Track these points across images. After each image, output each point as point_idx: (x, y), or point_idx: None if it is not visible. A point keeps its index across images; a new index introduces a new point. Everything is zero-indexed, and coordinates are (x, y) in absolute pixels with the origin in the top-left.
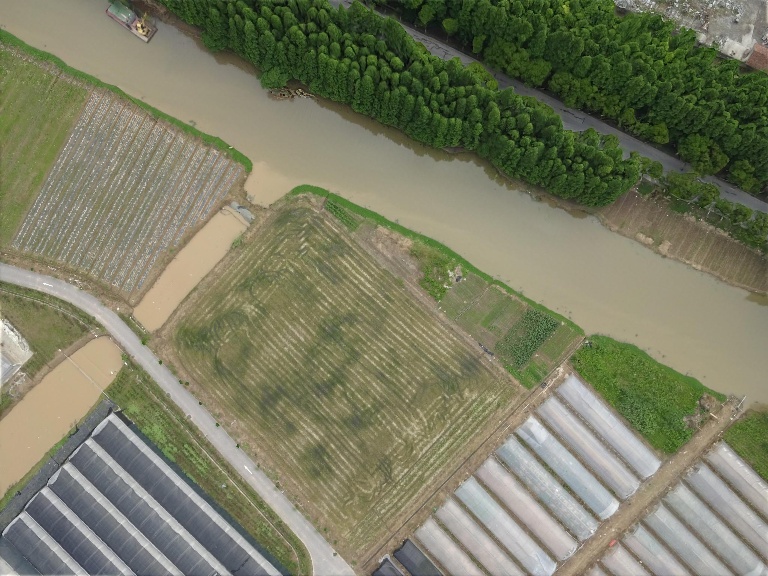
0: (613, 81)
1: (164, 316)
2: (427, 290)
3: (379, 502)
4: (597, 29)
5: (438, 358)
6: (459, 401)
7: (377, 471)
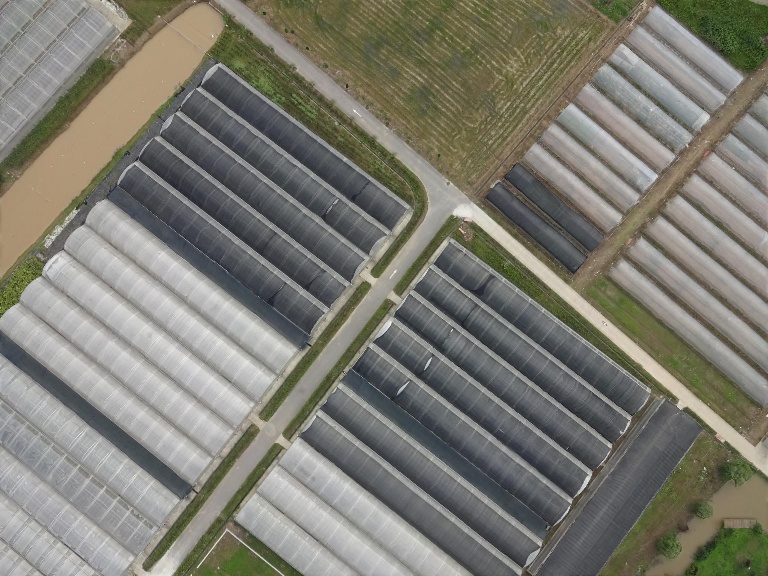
0: None
1: None
2: None
3: (486, 134)
4: None
5: (530, 1)
6: (553, 38)
7: (481, 106)
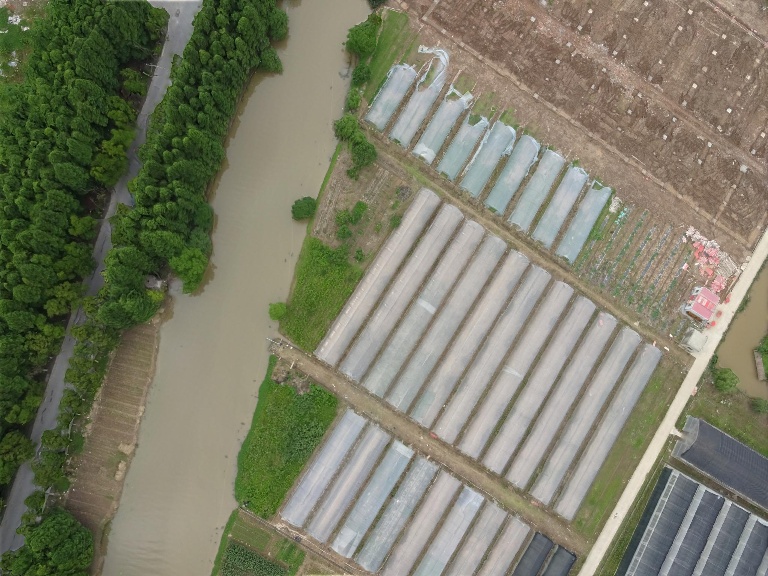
0: None
1: None
2: None
3: None
4: None
5: None
6: None
7: None
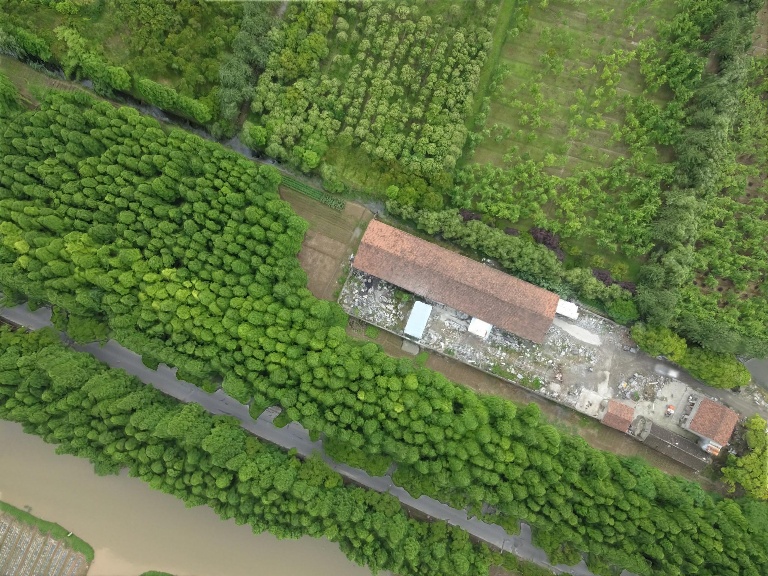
0: (454, 485)
1: None
2: None
3: None
4: (431, 437)
5: None
6: None
7: None
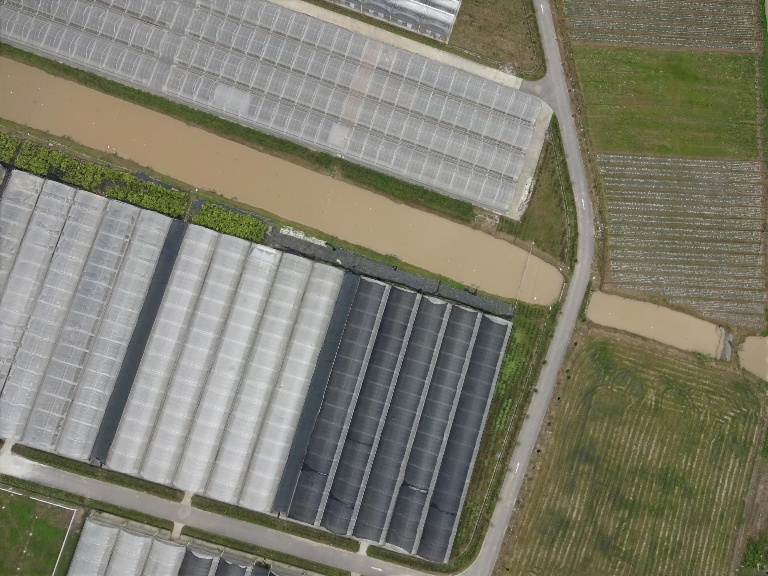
0: None
1: (606, 321)
2: (747, 550)
3: None
4: None
5: None
6: None
7: None
